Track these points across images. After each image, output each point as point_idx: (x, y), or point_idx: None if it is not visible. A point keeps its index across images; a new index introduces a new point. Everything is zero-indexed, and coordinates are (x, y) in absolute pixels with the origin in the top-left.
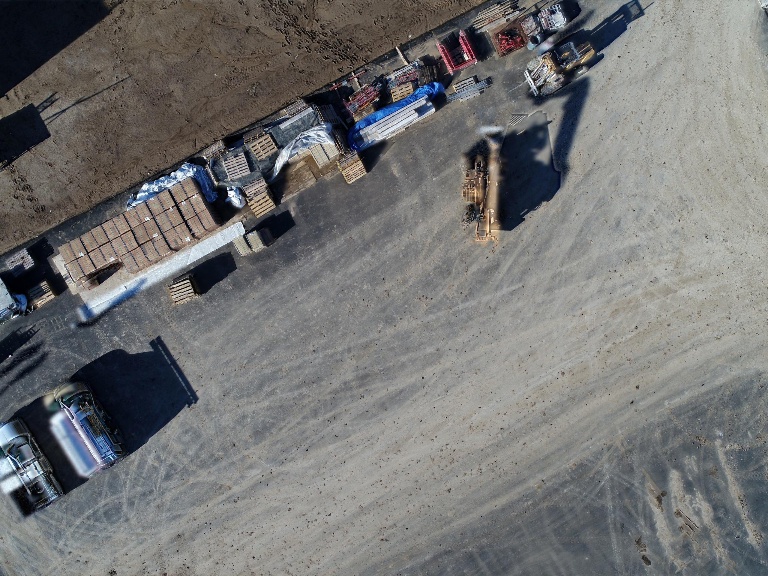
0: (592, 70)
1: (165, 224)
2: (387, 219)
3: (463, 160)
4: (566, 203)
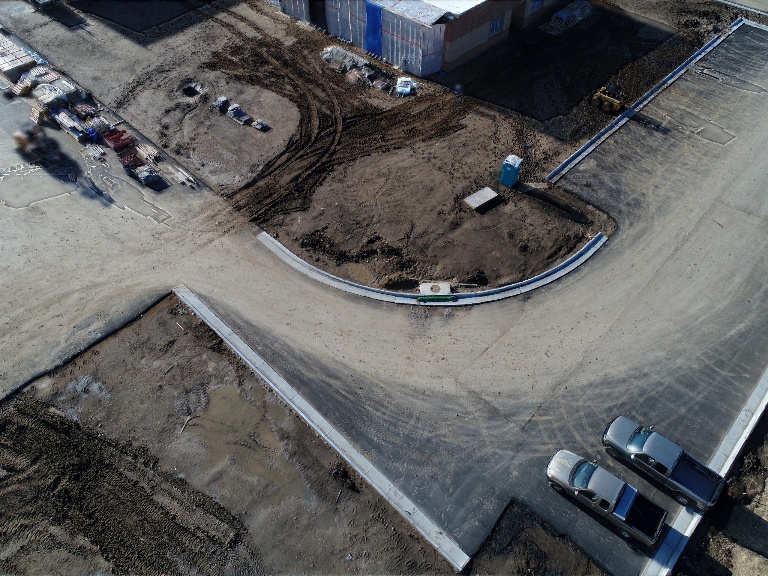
0: (112, 206)
1: (6, 57)
2: (3, 137)
3: (43, 160)
4: (2, 214)
